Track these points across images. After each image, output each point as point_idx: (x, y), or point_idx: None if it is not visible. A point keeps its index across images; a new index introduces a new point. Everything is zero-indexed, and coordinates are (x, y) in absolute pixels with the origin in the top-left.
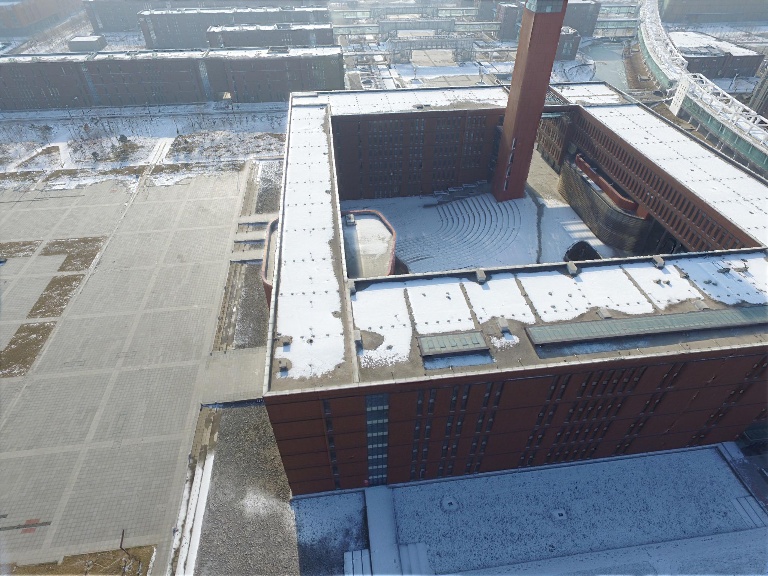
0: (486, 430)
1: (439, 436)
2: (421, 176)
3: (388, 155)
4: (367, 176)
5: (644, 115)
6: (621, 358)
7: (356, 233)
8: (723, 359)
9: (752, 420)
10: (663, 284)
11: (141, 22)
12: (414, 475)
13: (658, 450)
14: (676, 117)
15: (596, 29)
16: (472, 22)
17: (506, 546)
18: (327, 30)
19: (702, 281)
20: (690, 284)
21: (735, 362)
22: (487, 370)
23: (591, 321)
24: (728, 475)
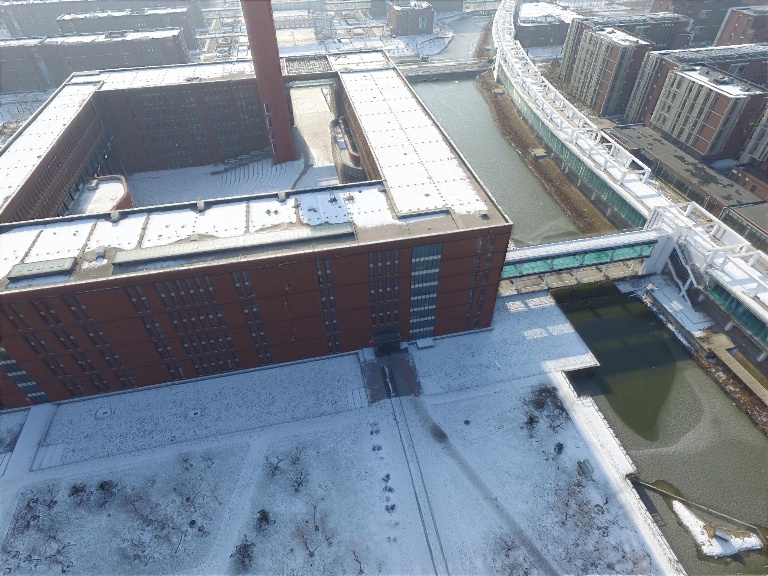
0: (106, 343)
1: (61, 350)
2: (207, 146)
3: (167, 127)
4: (153, 148)
5: (391, 78)
6: (175, 269)
7: (93, 196)
8: (277, 267)
9: (371, 325)
10: (271, 213)
11: (1, 13)
12: (74, 392)
13: (305, 358)
14: (496, 82)
15: (466, 3)
16: (342, 1)
17: (135, 440)
18: (180, 14)
19: (306, 209)
20: (294, 212)
21: (292, 269)
22: (53, 285)
23: (176, 244)
24: (356, 373)
